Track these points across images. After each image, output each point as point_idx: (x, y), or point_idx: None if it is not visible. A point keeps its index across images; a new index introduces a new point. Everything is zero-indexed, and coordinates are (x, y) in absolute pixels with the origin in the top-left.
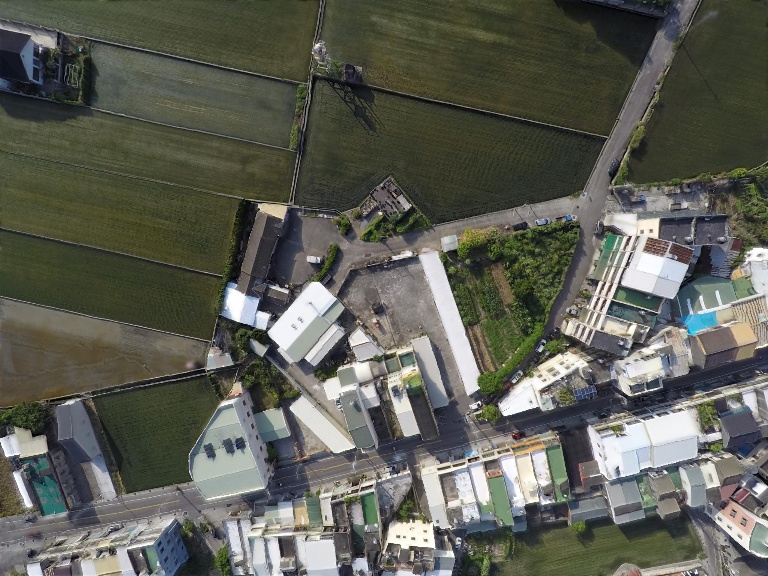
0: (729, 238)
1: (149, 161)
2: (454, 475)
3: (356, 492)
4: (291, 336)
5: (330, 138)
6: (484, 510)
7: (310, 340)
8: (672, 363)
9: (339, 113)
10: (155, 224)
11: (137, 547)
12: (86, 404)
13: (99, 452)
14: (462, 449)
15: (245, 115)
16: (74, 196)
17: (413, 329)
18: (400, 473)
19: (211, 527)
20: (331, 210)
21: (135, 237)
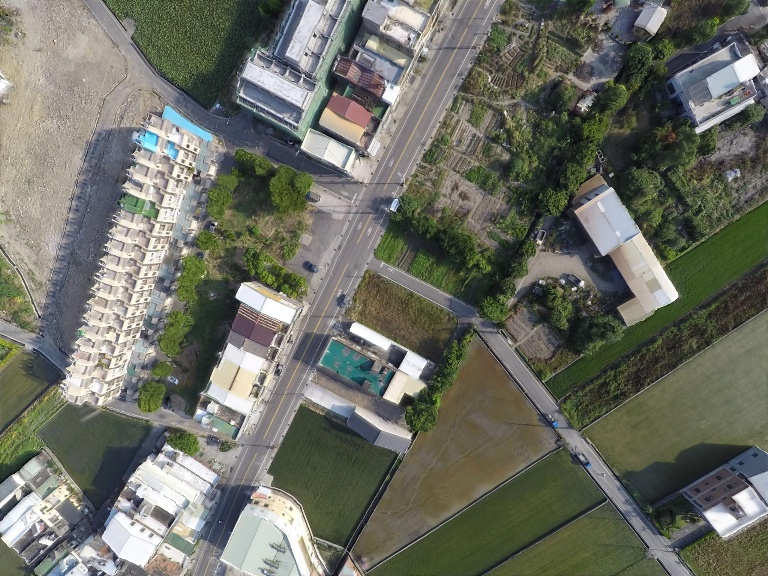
0: None
1: None
2: None
3: None
4: None
5: None
6: None
7: None
8: None
9: None
10: None
11: None
12: None
13: None
14: None
15: None
16: None
17: None
18: None
19: (223, 441)
20: None
21: None
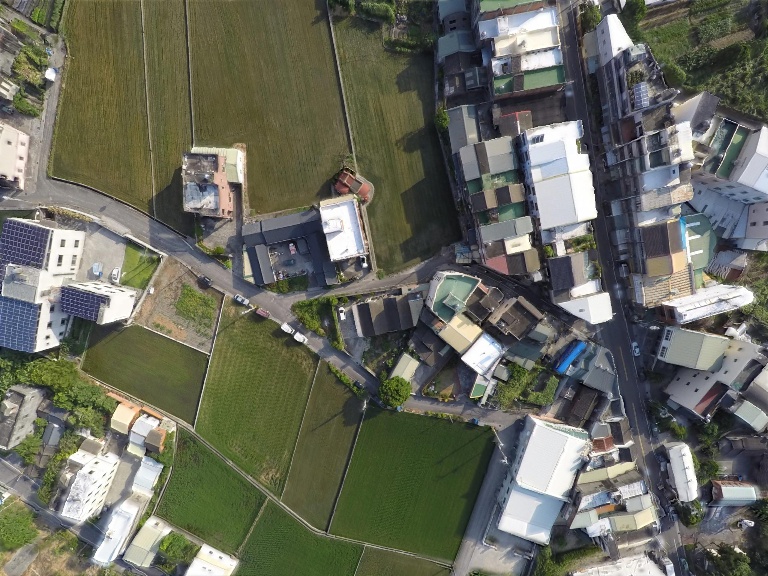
0: (744, 265)
1: None
2: None
3: None
4: None
5: None
6: None
7: None
8: (662, 190)
9: None
10: None
11: None
12: None
13: None
14: None
15: None
16: None
17: None
18: None
19: None
20: None
21: None
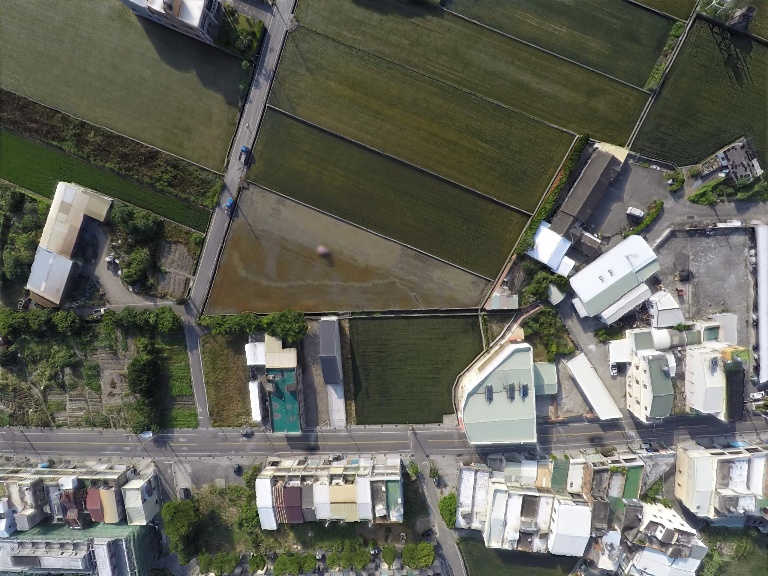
0: None
1: (488, 77)
2: (731, 462)
3: (620, 463)
4: (596, 288)
5: (691, 85)
6: (758, 504)
7: (614, 296)
8: None
9: (710, 60)
10: (474, 146)
11: (381, 480)
12: (341, 324)
13: (342, 376)
14: (725, 438)
15: (607, 45)
16: (396, 101)
17: (714, 304)
18: (661, 451)
19: None
20: (669, 162)
21: (448, 156)
